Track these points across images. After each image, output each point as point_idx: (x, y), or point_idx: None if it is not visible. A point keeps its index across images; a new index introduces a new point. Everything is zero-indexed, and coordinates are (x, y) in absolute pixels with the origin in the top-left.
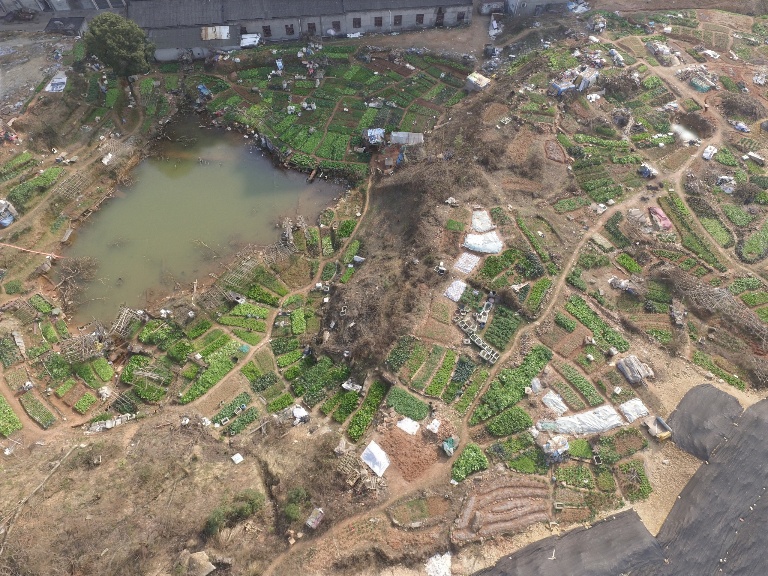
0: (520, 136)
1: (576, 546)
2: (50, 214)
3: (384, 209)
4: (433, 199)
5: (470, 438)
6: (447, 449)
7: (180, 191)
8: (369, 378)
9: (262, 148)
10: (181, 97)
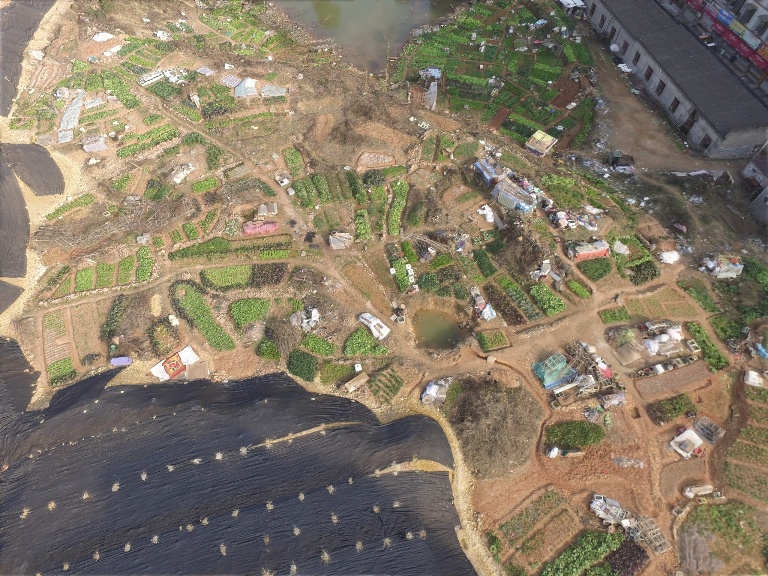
0: (398, 134)
1: (5, 89)
2: None
3: None
4: None
5: None
6: (91, 57)
7: (379, 7)
8: None
9: None
10: None
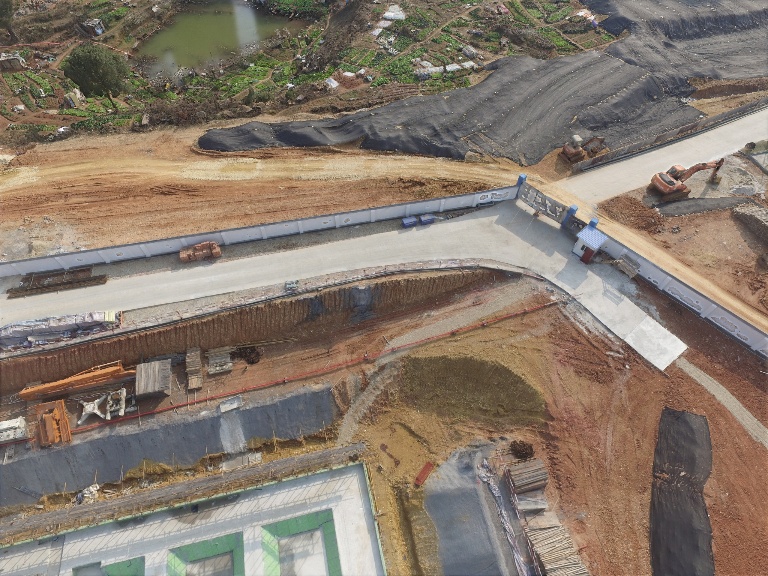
0: None
1: None
2: (124, 33)
3: (338, 22)
4: (366, 3)
5: None
6: (368, 77)
7: (205, 26)
8: (328, 66)
9: (257, 5)
10: None
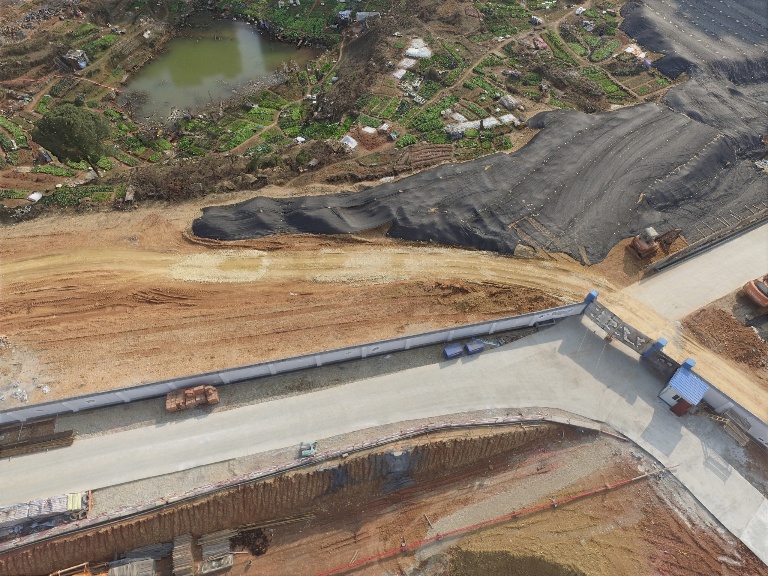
0: (447, 3)
1: None
2: (111, 65)
3: (353, 53)
4: (385, 35)
5: (407, 133)
6: (392, 135)
7: (203, 55)
8: (344, 117)
9: (261, 29)
10: (196, 1)
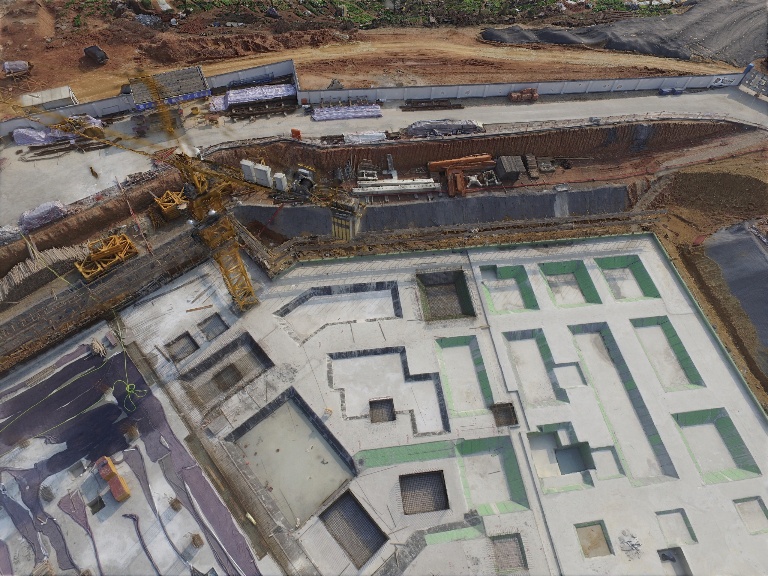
0: None
1: None
2: None
3: None
4: None
5: None
6: (589, 5)
7: None
8: None
9: None
10: None
